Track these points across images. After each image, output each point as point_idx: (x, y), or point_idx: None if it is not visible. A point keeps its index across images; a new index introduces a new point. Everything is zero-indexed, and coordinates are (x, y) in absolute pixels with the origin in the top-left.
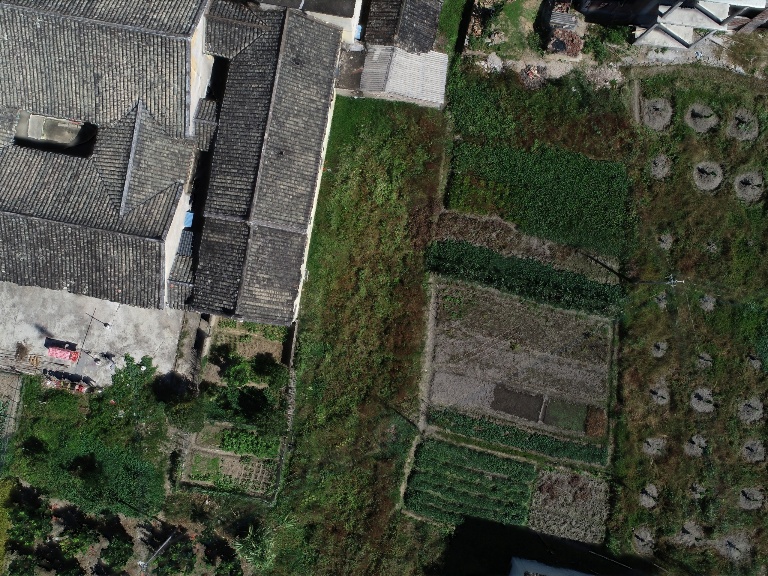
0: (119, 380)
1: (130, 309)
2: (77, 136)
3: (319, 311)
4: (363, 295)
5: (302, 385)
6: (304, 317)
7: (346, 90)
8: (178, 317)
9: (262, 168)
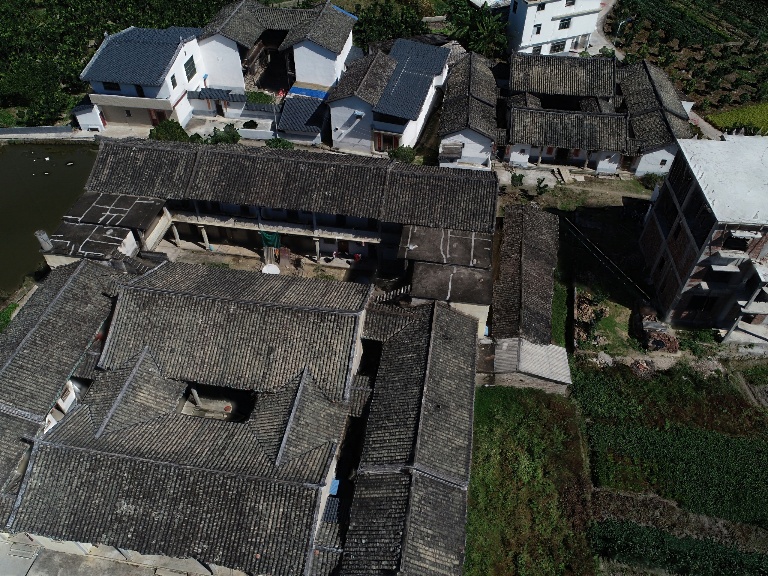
0: None
1: None
2: None
3: None
4: None
5: None
6: None
7: (480, 375)
8: None
9: (423, 417)
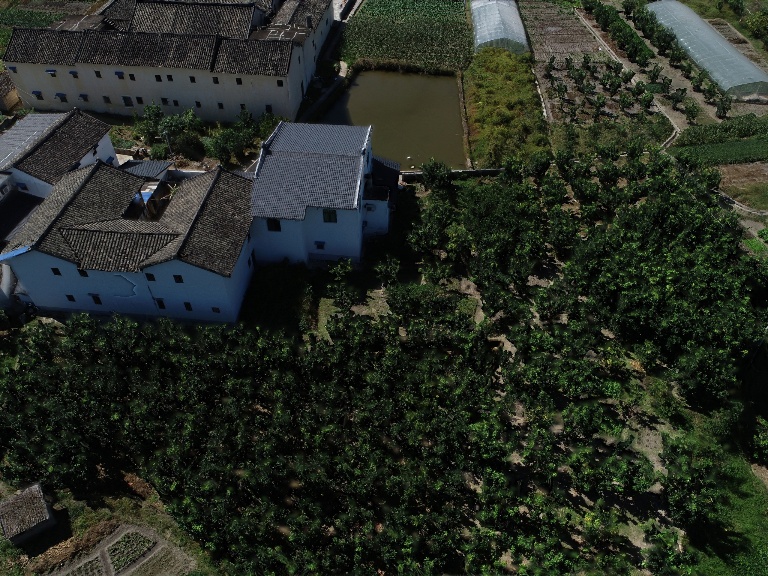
0: None
1: None
2: None
3: None
4: None
5: None
6: None
7: None
8: None
9: None
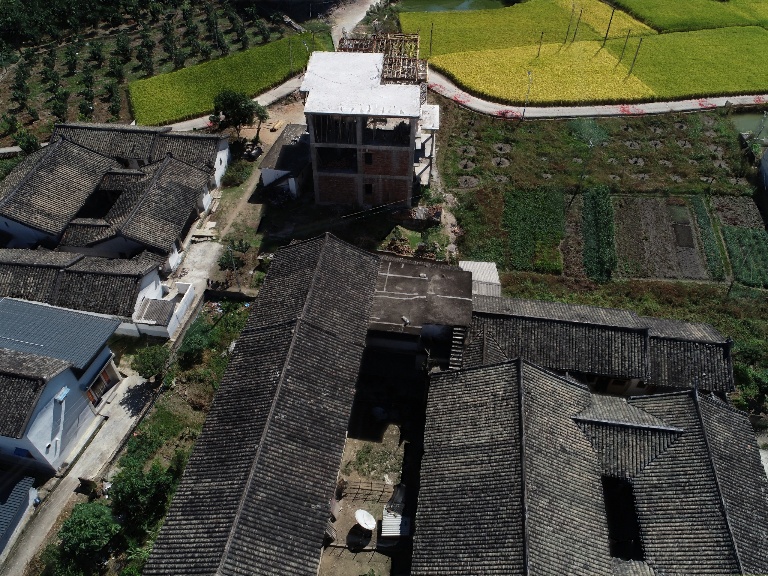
0: None
1: None
2: None
3: None
4: None
5: None
6: None
7: None
8: None
9: None
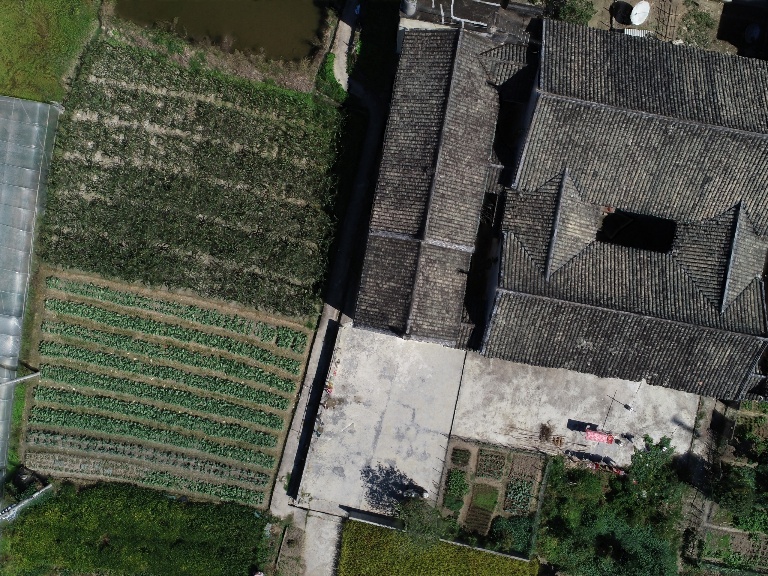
0: (639, 460)
1: (649, 391)
2: (605, 223)
3: None
4: None
5: None
6: None
7: None
8: (695, 399)
9: None
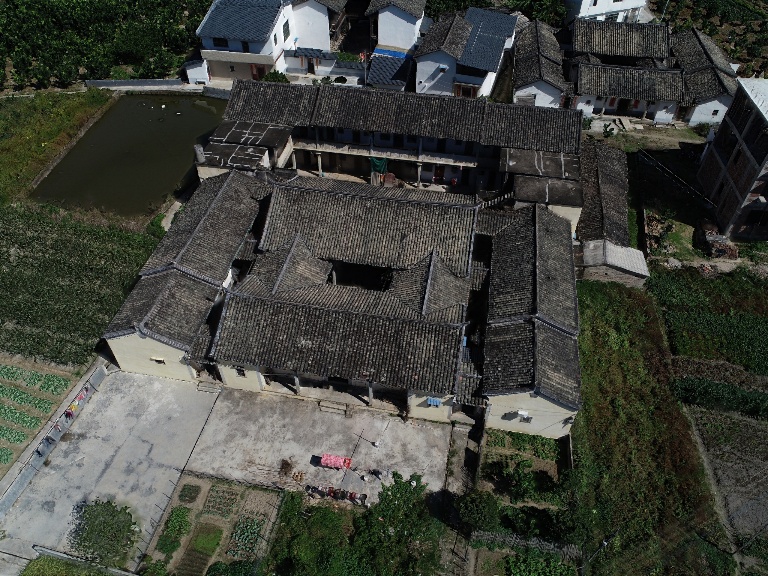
0: (387, 497)
1: (397, 430)
2: None
3: (584, 435)
4: (624, 420)
5: (585, 507)
6: (573, 435)
7: None
8: (445, 437)
9: (538, 283)
